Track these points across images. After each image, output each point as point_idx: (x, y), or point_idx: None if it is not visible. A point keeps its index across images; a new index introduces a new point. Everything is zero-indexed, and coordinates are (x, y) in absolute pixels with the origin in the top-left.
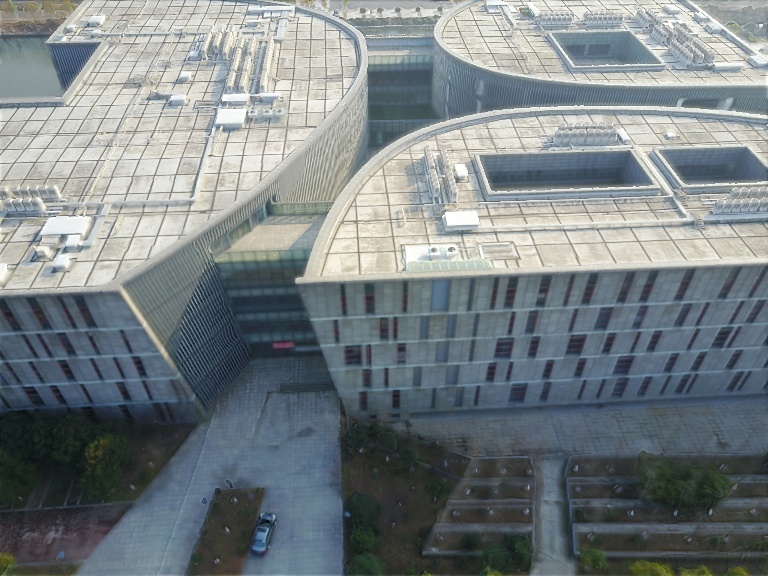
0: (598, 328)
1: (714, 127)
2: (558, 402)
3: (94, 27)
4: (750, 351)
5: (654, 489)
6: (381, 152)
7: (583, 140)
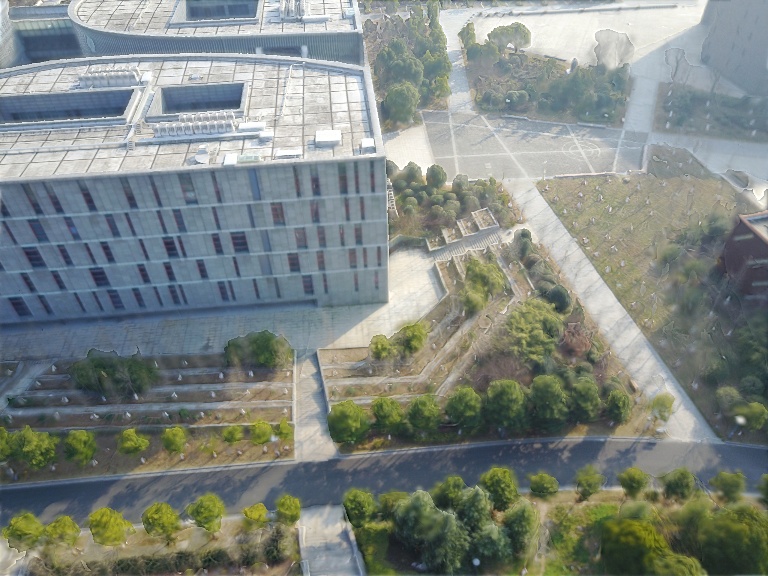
0: (43, 240)
1: (244, 69)
2: (68, 316)
3: None
4: (211, 261)
5: (78, 377)
6: None
7: (106, 82)
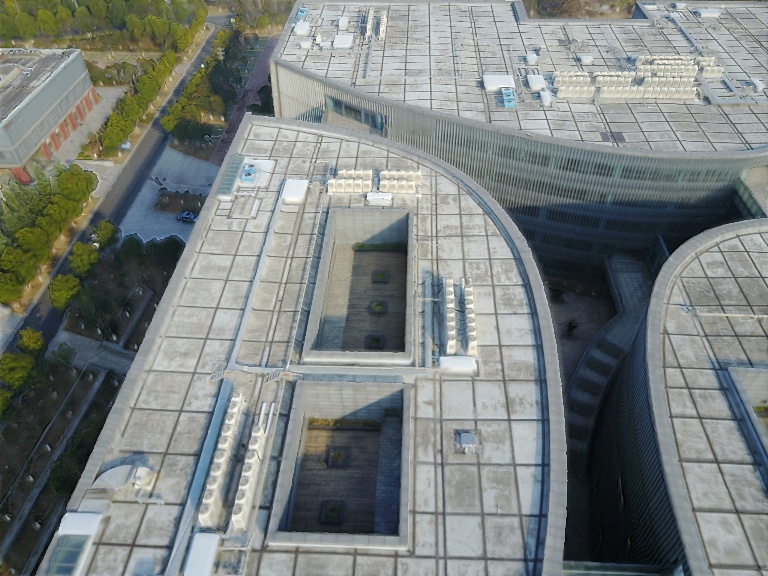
0: None
1: (502, 534)
2: None
3: (693, 15)
4: None
5: (90, 419)
6: (422, 152)
7: None
